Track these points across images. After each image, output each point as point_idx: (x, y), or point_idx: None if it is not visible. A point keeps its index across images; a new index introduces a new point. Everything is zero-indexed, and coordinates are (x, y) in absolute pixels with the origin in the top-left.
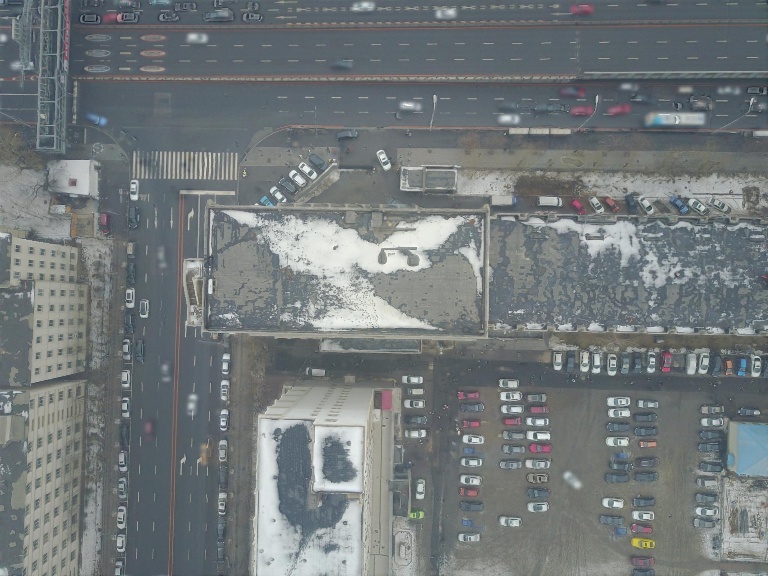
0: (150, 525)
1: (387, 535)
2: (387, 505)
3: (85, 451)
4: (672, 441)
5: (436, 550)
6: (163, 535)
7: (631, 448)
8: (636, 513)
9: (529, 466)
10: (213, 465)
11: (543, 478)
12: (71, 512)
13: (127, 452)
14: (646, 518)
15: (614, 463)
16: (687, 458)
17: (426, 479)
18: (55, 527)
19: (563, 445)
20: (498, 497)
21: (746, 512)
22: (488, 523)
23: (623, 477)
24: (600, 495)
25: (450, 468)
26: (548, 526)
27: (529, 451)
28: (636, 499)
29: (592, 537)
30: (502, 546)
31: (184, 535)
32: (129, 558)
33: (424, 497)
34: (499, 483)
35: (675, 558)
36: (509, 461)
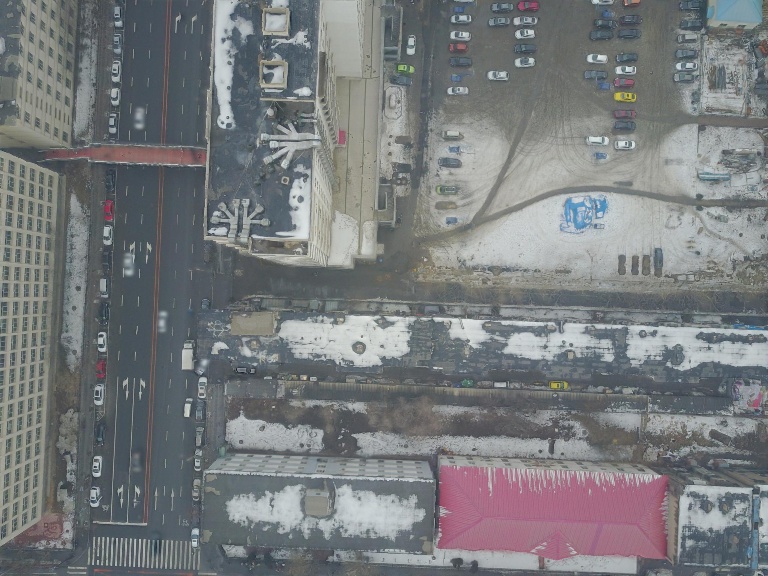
0: (144, 80)
1: (378, 57)
2: (379, 29)
3: (81, 9)
4: (655, 2)
5: (425, 105)
6: (157, 92)
7: (615, 8)
8: (619, 67)
9: (517, 23)
10: (208, 23)
11: (530, 31)
12: (66, 54)
13: (122, 9)
14: (628, 70)
15: (599, 19)
16: (669, 18)
17: (417, 37)
18: (51, 48)
19: (550, 6)
20: (486, 55)
21: (724, 69)
22: (476, 79)
23: (607, 32)
24: (585, 53)
25: (440, 27)
26: (534, 82)
27: (517, 10)
28: (619, 54)
29: (576, 93)
30: (489, 101)
31: (178, 91)
32: (123, 113)
33: (414, 53)
34: (488, 41)
35: (655, 113)
36: (498, 17)
